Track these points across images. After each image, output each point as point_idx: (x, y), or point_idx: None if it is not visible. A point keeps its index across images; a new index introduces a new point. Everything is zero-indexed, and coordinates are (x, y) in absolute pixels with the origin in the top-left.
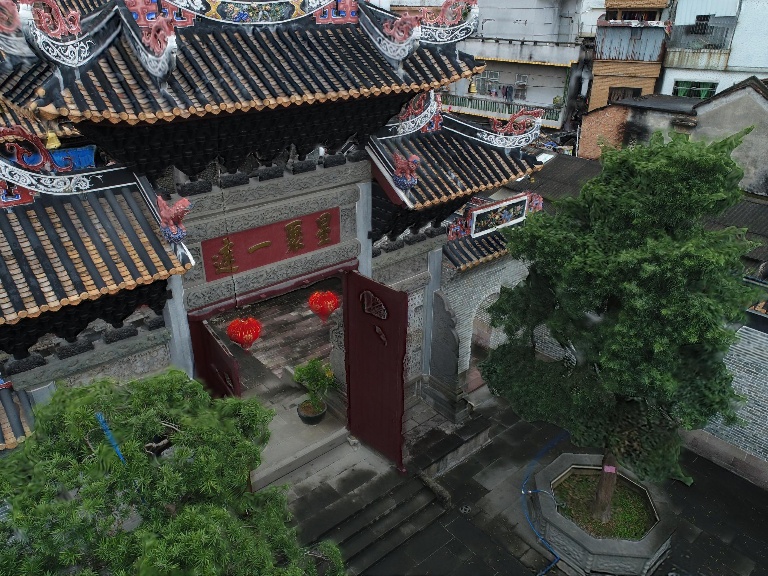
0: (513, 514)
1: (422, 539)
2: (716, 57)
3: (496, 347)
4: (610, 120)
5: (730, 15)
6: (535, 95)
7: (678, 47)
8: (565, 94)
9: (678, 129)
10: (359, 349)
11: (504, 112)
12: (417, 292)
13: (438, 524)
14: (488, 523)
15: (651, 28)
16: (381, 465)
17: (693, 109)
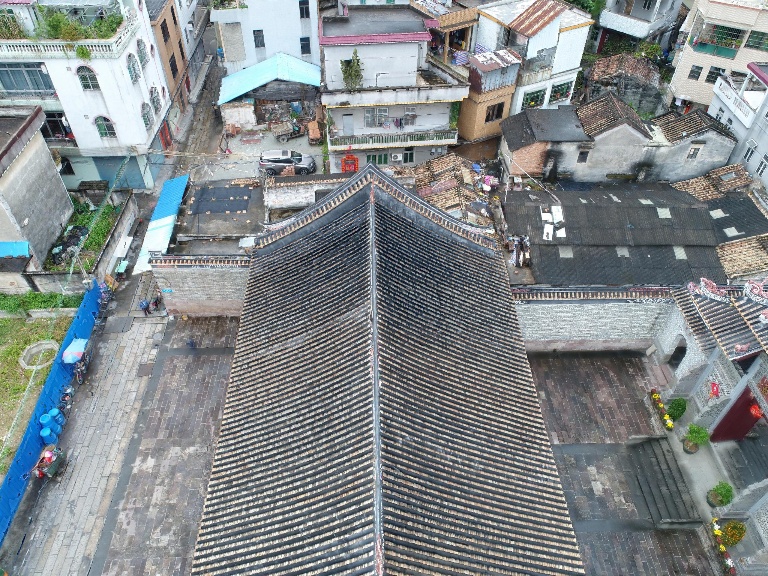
0: (759, 421)
1: (767, 456)
2: (546, 73)
3: (672, 353)
4: (535, 150)
5: (554, 46)
6: (424, 120)
7: (527, 72)
8: (452, 117)
9: (582, 149)
10: (740, 413)
11: (405, 141)
12: None
13: (761, 446)
14: (761, 431)
15: (513, 64)
16: (732, 444)
17: (592, 138)
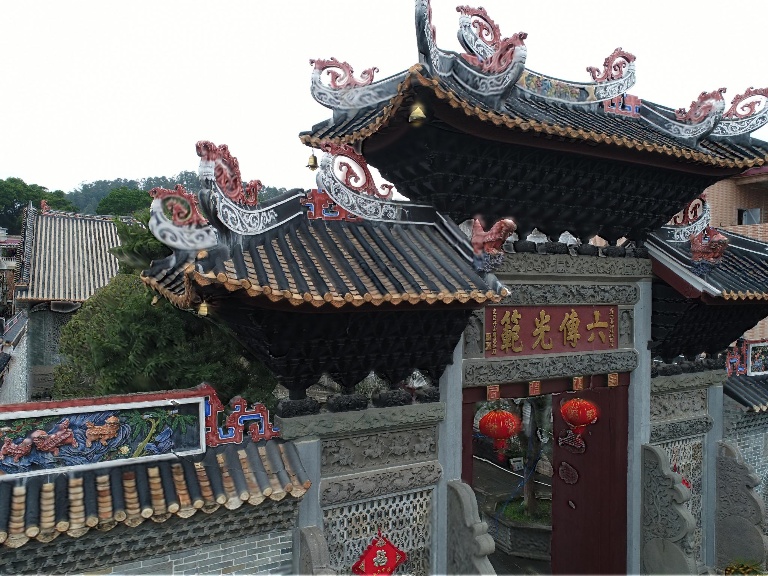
0: None
1: None
2: None
3: None
4: None
5: None
6: None
7: None
8: None
9: None
10: None
11: None
12: (335, 514)
13: None
14: None
15: None
16: None
17: None
